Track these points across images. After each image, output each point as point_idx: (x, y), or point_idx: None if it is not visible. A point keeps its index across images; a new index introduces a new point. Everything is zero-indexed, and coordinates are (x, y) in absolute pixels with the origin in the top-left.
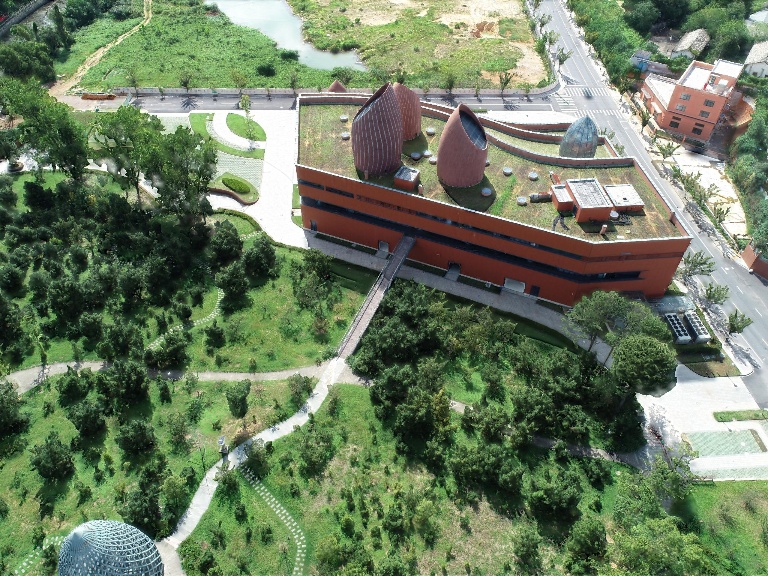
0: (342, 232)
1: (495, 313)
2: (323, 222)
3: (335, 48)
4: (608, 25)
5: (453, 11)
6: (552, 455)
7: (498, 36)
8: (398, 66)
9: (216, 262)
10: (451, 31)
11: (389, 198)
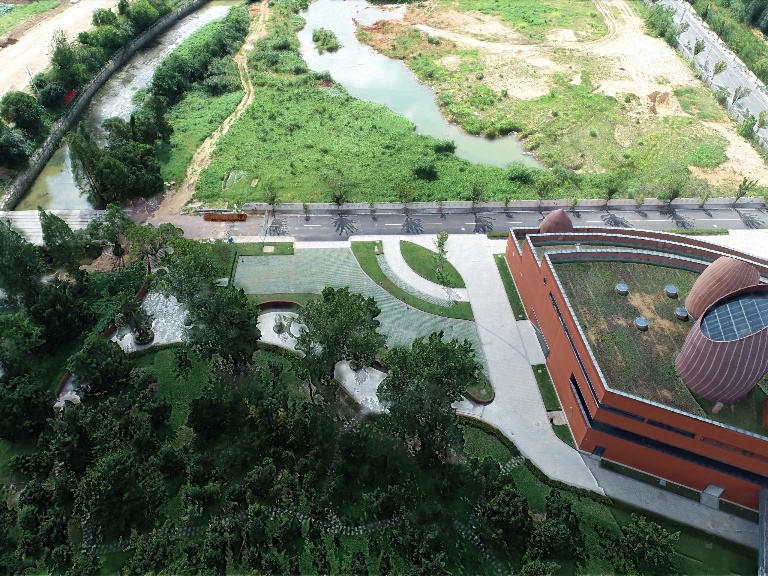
0: (646, 465)
1: None
2: (618, 450)
3: (492, 133)
4: None
5: (611, 77)
6: None
7: (683, 113)
8: (580, 159)
9: (501, 542)
10: (624, 106)
11: (764, 449)
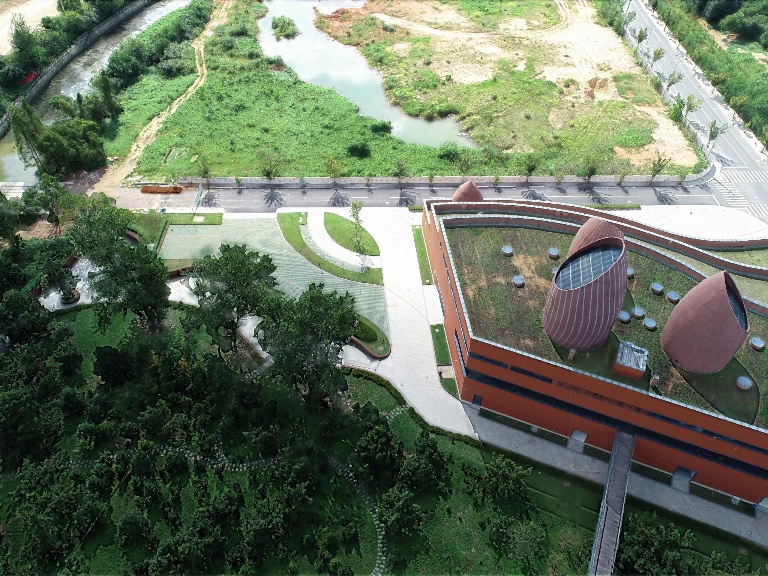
0: (519, 413)
1: (763, 555)
2: (493, 399)
3: (430, 115)
4: (757, 88)
5: (555, 63)
6: None
7: (618, 97)
8: (511, 140)
9: (368, 476)
10: (562, 91)
11: (609, 392)
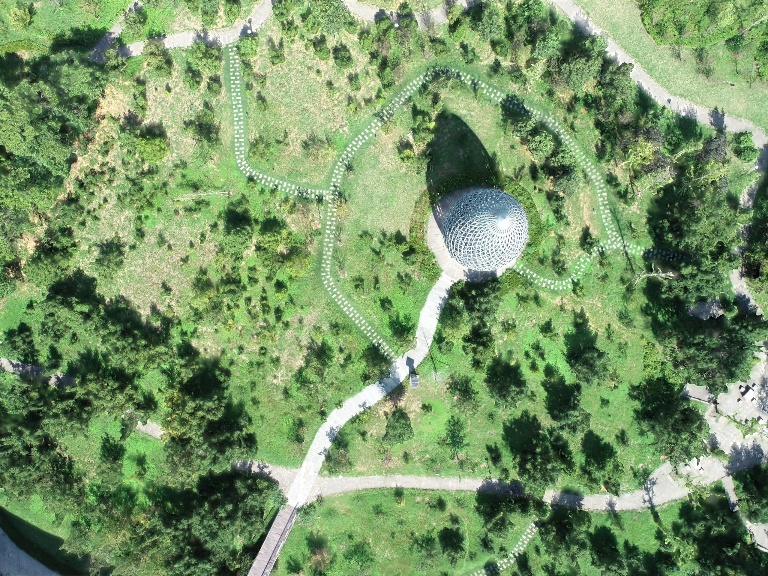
0: None
1: None
2: None
3: None
4: None
5: None
6: (64, 366)
7: None
8: None
9: None
10: None
11: None
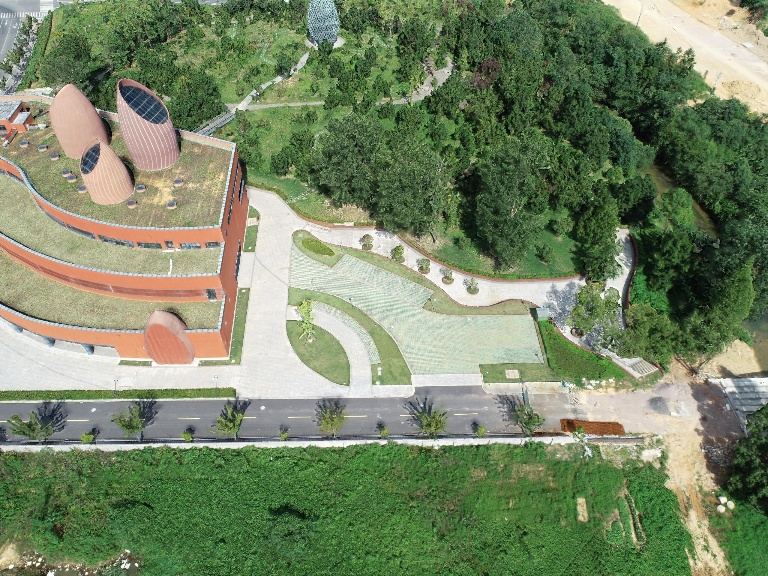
0: None
1: None
2: None
3: None
4: None
5: None
6: None
7: None
8: None
9: None
10: None
11: None
